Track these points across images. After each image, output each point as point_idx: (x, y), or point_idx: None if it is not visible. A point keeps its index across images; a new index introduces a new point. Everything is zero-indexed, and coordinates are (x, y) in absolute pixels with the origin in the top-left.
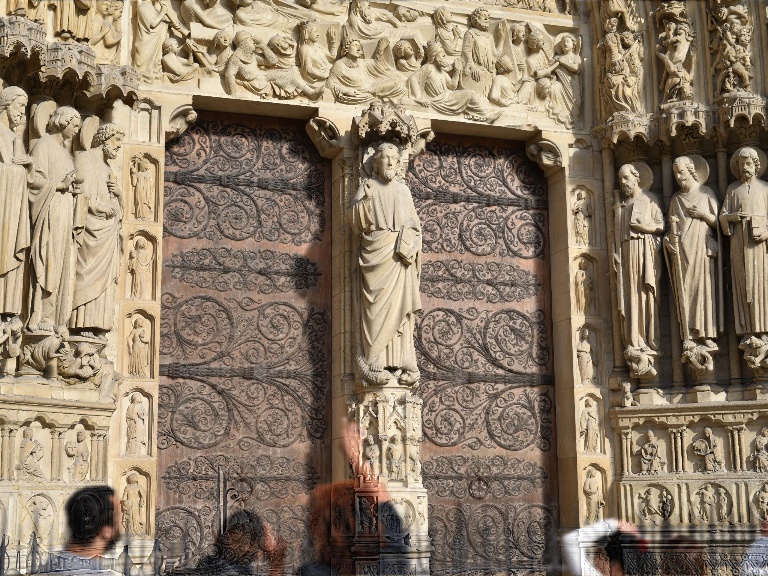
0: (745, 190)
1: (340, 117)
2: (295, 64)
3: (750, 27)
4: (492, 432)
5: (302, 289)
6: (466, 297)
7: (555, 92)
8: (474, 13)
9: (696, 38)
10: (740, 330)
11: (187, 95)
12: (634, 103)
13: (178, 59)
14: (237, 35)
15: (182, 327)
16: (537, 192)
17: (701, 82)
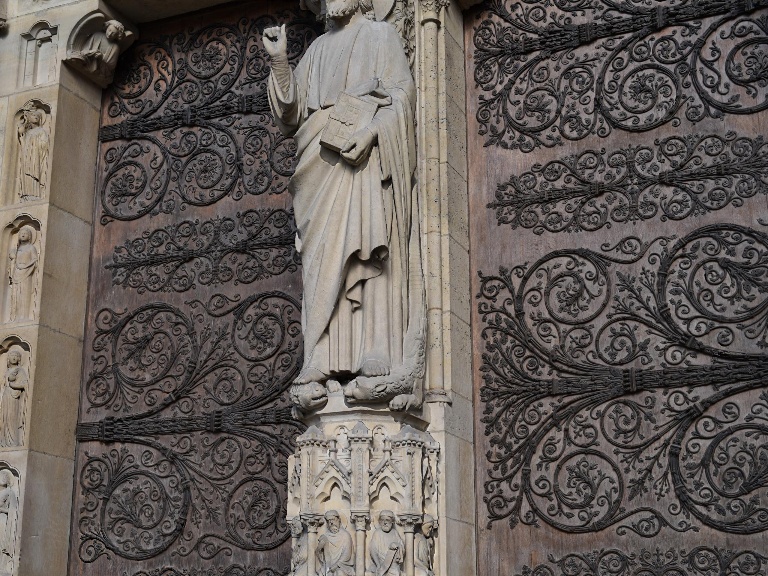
0: None
1: None
2: None
3: None
4: (686, 495)
5: None
6: (615, 219)
7: None
8: None
9: None
10: None
11: None
12: None
13: None
14: None
15: (123, 359)
16: None
17: None
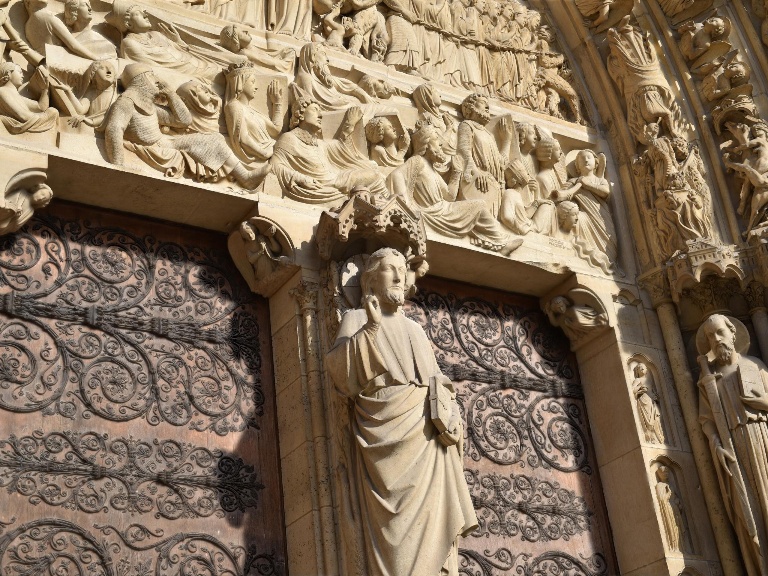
0: None
1: (292, 220)
2: (218, 130)
3: None
4: None
5: (233, 512)
6: (492, 531)
7: (581, 224)
8: (468, 99)
9: None
10: None
11: (38, 153)
12: (708, 230)
13: (21, 98)
14: (128, 67)
15: None
16: (564, 373)
17: None
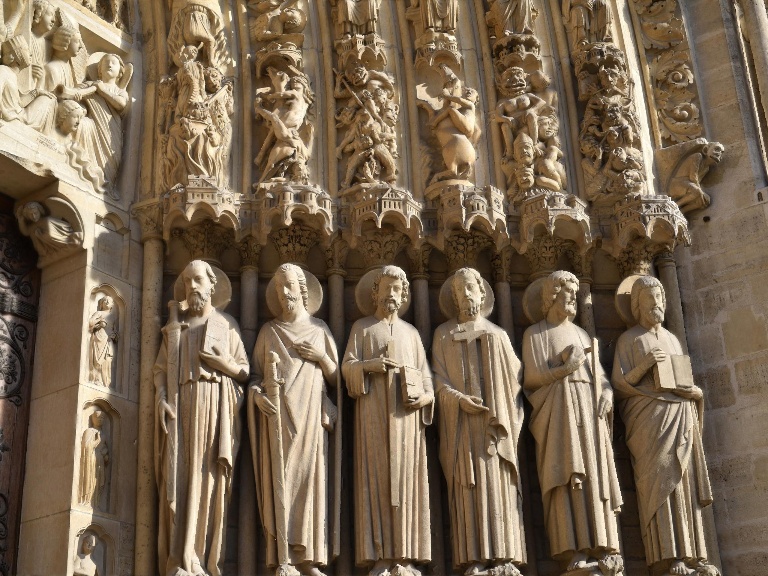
0: (386, 329)
1: None
2: None
3: (395, 105)
4: None
5: None
6: None
7: (83, 130)
8: None
9: (315, 103)
10: (372, 553)
11: None
12: (217, 171)
13: None
14: None
15: None
16: (21, 288)
17: (319, 165)
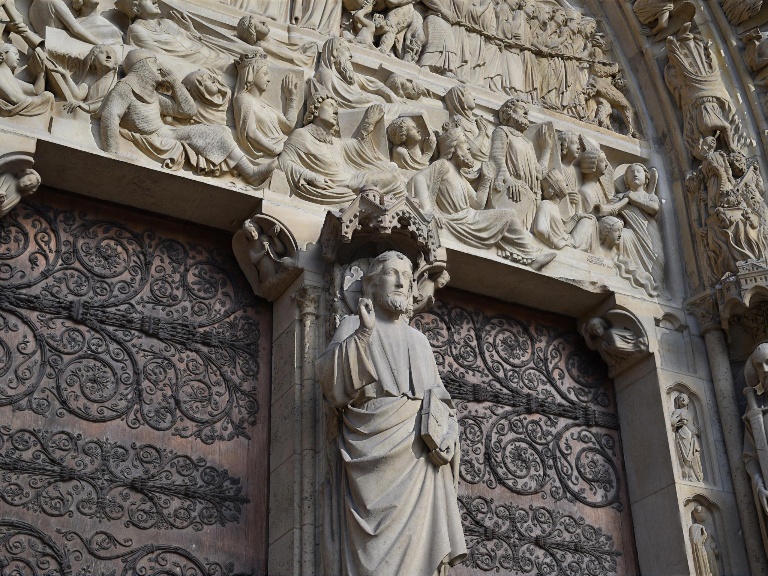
0: None
1: (298, 220)
2: (225, 123)
3: None
4: None
5: (211, 525)
6: (503, 565)
7: (625, 241)
8: (506, 104)
9: None
10: None
11: (26, 137)
12: (763, 252)
13: (16, 80)
14: (130, 52)
15: None
16: (599, 400)
17: None
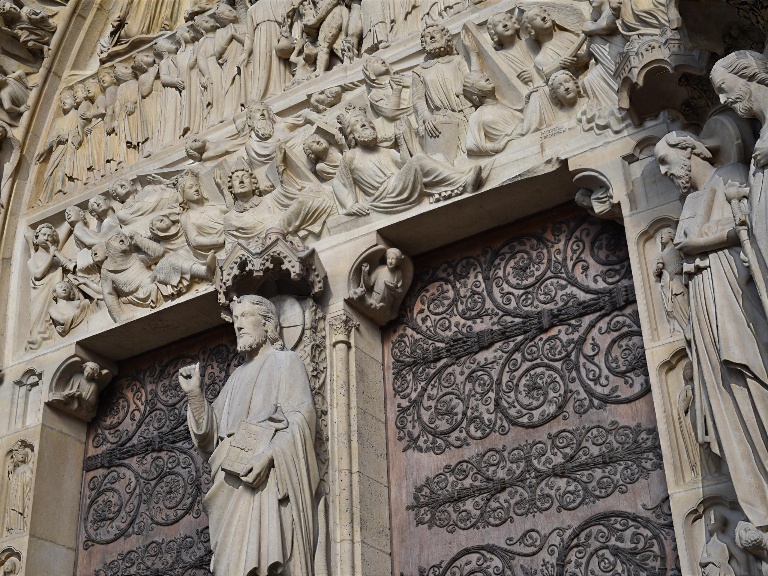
0: None
1: None
2: (187, 244)
3: None
4: None
5: None
6: (517, 513)
7: (591, 85)
8: None
9: None
10: None
11: (70, 345)
12: (659, 18)
13: (70, 304)
14: None
15: None
16: None
17: None
